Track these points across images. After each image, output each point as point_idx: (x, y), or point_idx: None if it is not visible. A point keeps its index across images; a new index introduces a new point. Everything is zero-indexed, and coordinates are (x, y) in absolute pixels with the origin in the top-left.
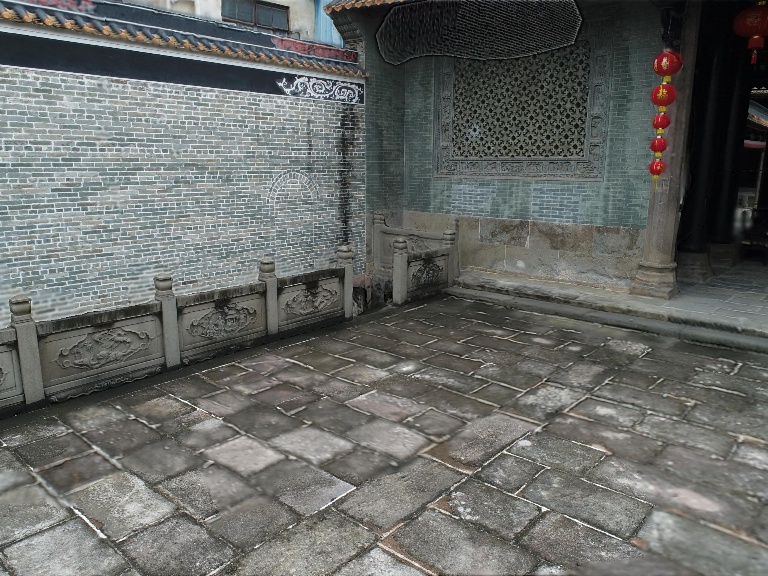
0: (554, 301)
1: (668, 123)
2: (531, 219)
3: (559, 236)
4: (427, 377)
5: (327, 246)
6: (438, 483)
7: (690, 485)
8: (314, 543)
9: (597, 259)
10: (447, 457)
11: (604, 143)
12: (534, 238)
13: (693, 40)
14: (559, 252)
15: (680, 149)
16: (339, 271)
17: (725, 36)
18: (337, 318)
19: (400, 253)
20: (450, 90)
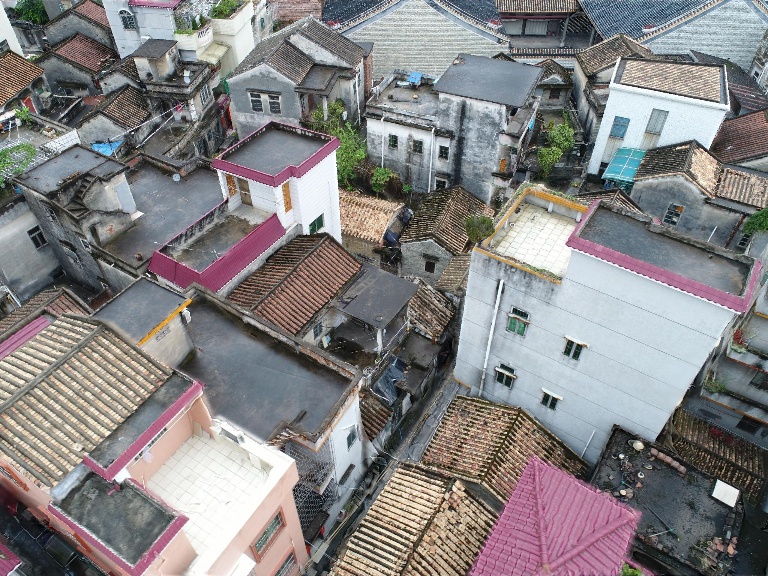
0: None
1: None
2: None
3: None
4: None
5: None
6: None
7: None
8: None
9: None
10: None
11: None
12: None
13: None
14: None
15: None
16: None
17: None
18: None
19: None
20: None
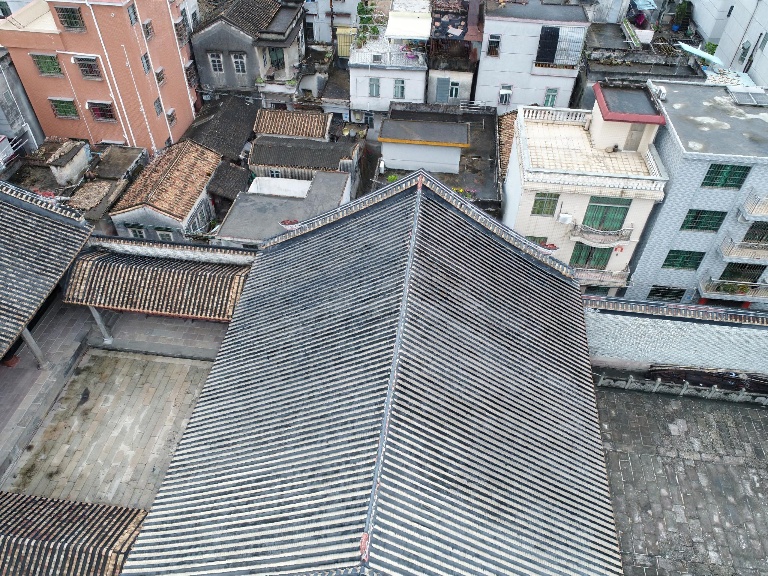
0: None
1: None
2: None
3: None
4: None
5: None
6: (692, 564)
7: None
8: (719, 571)
9: None
10: (684, 567)
11: None
12: None
13: None
14: None
15: None
16: None
17: None
18: None
19: None
20: None
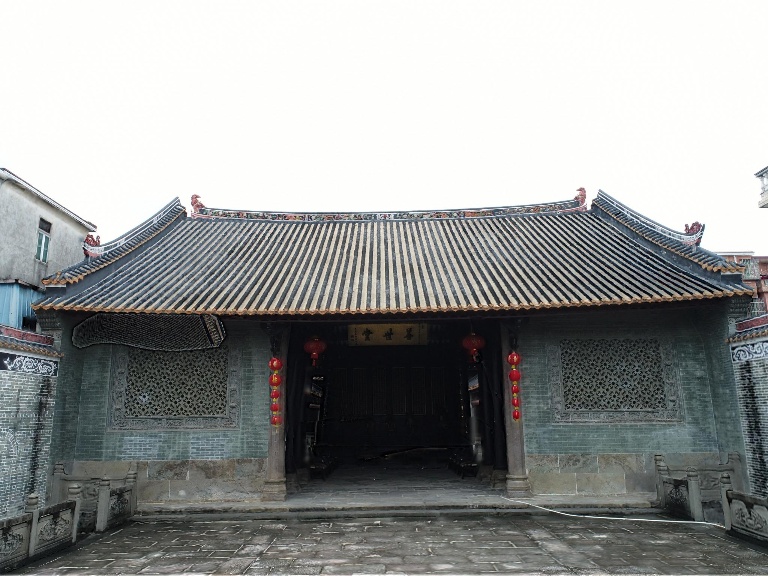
0: (217, 512)
1: (278, 395)
2: (190, 459)
3: (211, 469)
4: (174, 556)
5: (18, 495)
6: None
7: (332, 558)
8: None
9: (238, 482)
10: None
11: (239, 406)
12: (193, 472)
13: (285, 352)
14: (212, 480)
15: (283, 410)
16: (72, 504)
17: (300, 352)
18: (67, 543)
19: (105, 489)
20: (124, 368)
